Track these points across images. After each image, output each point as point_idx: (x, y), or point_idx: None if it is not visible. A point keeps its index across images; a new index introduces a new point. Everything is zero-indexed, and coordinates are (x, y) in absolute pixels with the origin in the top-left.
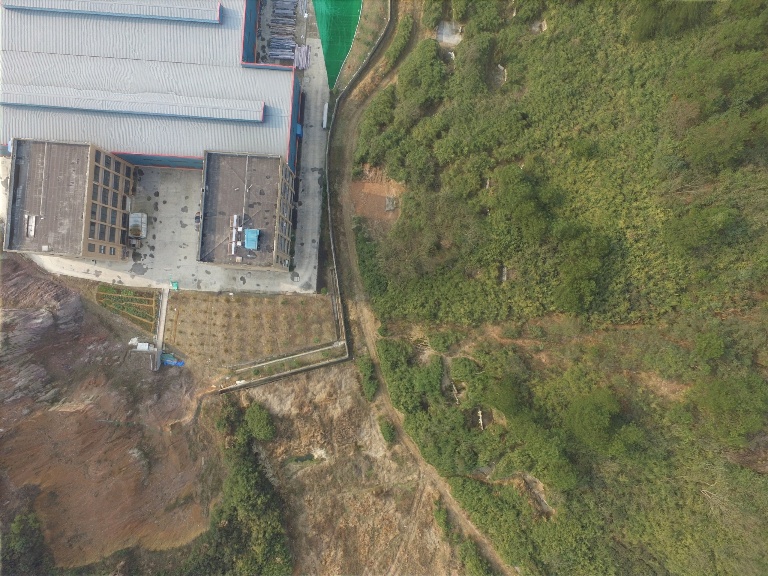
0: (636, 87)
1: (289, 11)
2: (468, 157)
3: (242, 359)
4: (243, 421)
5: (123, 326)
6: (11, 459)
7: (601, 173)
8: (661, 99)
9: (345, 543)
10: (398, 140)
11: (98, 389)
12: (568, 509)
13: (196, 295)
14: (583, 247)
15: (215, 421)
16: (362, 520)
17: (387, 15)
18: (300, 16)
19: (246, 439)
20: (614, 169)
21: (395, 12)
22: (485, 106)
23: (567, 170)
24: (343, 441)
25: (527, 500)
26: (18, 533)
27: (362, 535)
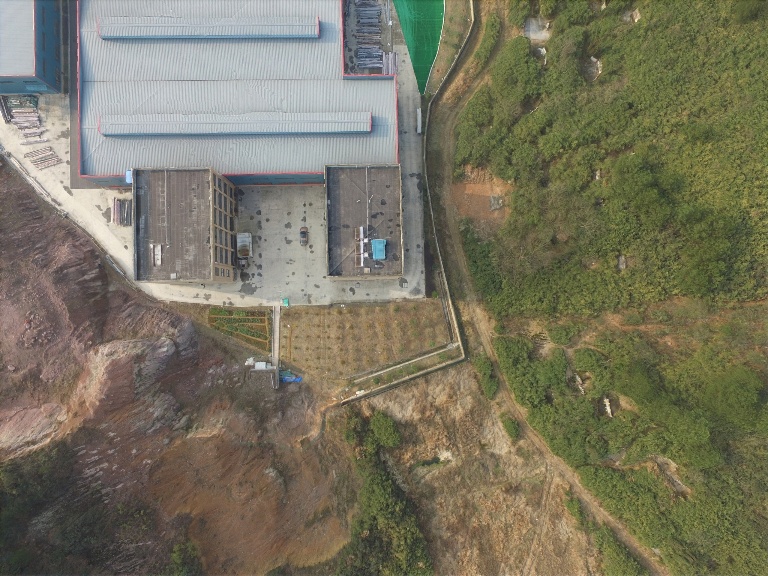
0: (741, 68)
1: (374, 20)
2: (576, 150)
3: (359, 369)
4: (368, 431)
5: (237, 347)
6: (160, 490)
7: (718, 155)
8: None
9: (480, 542)
10: (501, 139)
11: (225, 412)
12: (707, 487)
13: (308, 310)
14: (710, 229)
15: (343, 433)
16: (494, 517)
17: (470, 16)
18: (384, 24)
19: (376, 448)
20: (731, 150)
21: (477, 13)
22: (586, 99)
23: (682, 155)
24: (467, 441)
25: (663, 482)
26: (180, 562)
27: (496, 532)
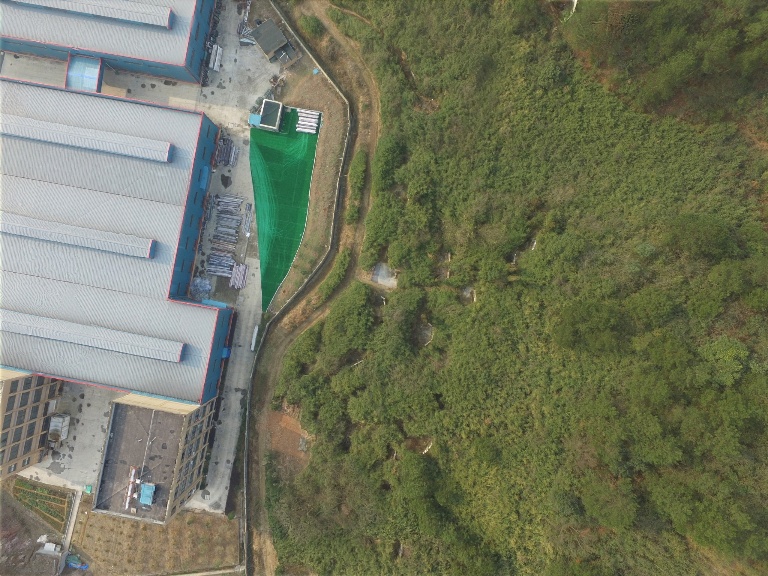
0: (551, 391)
1: (231, 230)
2: (378, 424)
3: (144, 571)
4: None
5: (35, 522)
6: None
7: (501, 482)
8: (571, 417)
9: None
10: (315, 388)
11: None
12: None
13: None
14: (470, 562)
15: None
16: None
17: (329, 242)
18: (242, 234)
19: None
20: (513, 483)
21: (337, 239)
22: (404, 371)
23: (469, 469)
24: None
25: None
26: None
27: None
